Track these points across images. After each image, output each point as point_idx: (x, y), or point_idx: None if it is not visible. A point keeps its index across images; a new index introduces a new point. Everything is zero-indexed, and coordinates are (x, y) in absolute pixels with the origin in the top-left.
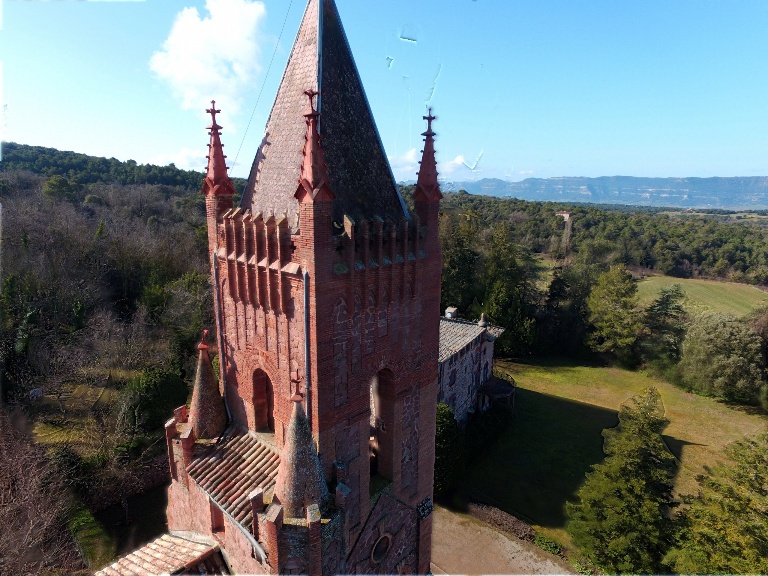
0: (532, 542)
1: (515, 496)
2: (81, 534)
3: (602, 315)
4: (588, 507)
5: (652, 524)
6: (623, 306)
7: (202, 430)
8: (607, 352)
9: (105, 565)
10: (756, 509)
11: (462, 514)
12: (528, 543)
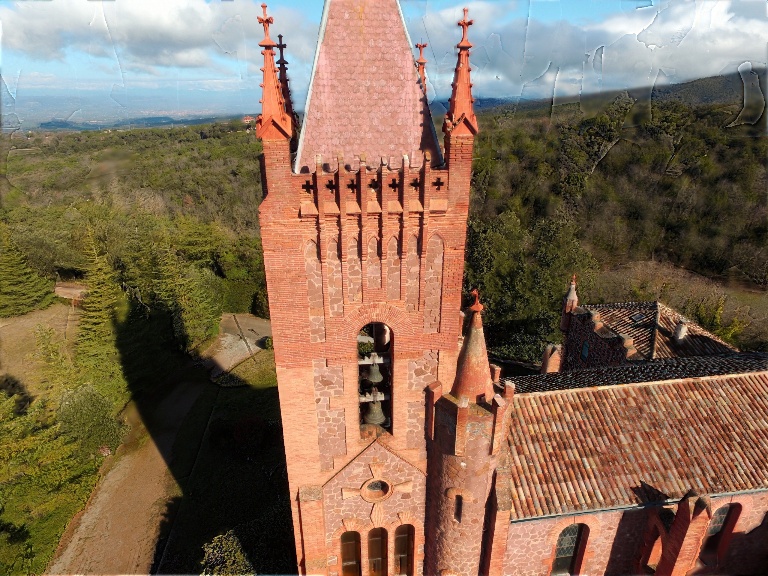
0: None
1: None
2: None
3: None
4: None
5: None
6: None
7: None
8: None
9: None
10: (0, 420)
11: None
12: None
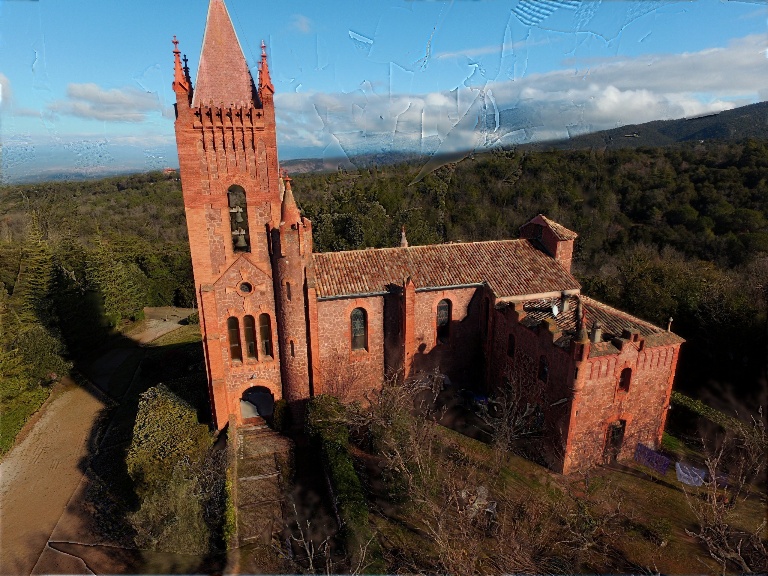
0: None
1: None
2: (384, 574)
3: None
4: None
5: None
6: None
7: None
8: None
9: (358, 511)
10: None
11: None
12: None
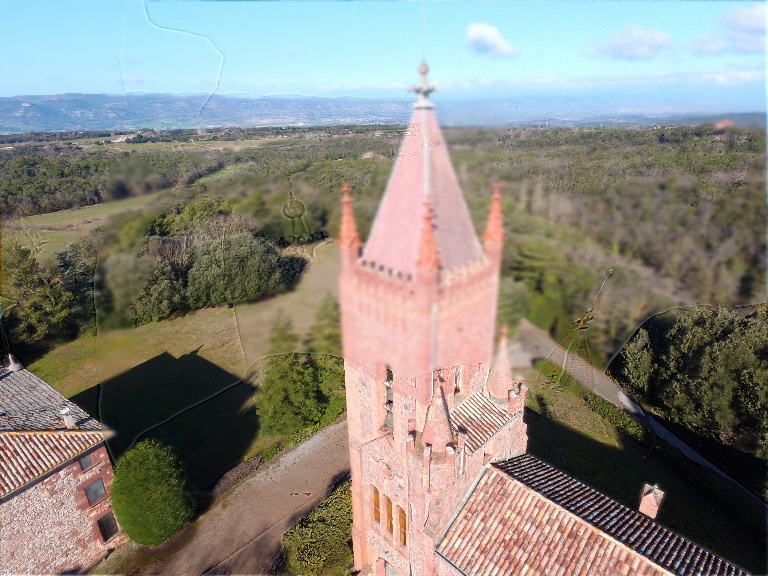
0: (263, 463)
1: (206, 463)
2: None
3: (21, 303)
4: (277, 407)
5: (310, 382)
6: (39, 284)
7: (453, 434)
8: (44, 337)
9: None
10: None
11: (213, 504)
12: (262, 466)
